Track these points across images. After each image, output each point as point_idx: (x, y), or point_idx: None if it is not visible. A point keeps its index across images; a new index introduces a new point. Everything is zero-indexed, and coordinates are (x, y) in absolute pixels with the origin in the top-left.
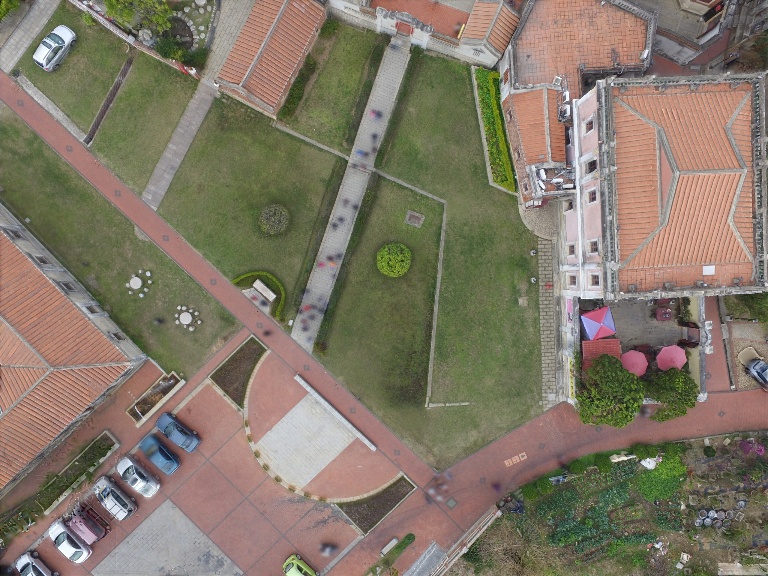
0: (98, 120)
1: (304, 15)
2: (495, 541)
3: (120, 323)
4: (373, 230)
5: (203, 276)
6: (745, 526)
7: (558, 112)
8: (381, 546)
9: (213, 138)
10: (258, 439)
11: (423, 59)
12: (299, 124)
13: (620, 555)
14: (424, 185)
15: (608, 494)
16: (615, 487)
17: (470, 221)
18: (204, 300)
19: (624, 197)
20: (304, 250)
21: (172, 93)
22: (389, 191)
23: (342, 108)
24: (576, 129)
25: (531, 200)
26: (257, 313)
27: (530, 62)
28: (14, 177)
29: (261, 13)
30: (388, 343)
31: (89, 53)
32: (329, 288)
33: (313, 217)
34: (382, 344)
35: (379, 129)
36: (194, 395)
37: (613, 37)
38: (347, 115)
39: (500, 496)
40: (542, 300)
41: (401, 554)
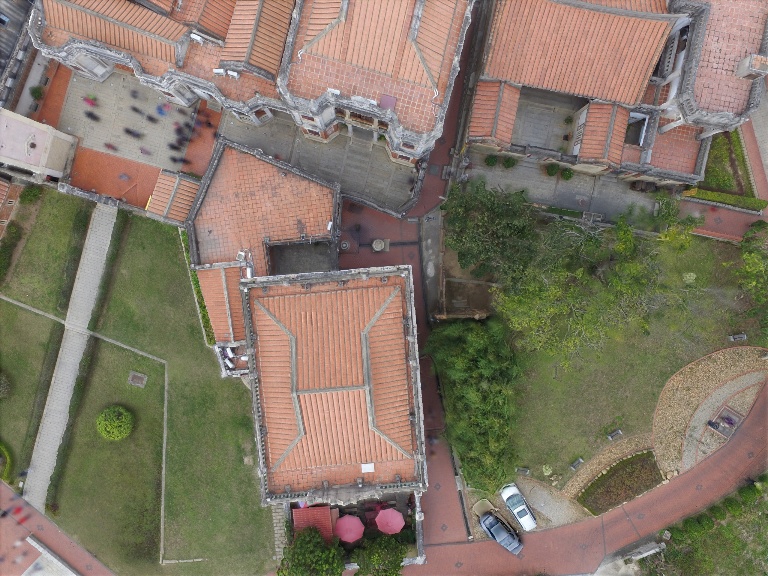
0: None
1: None
2: None
3: None
4: (96, 391)
5: None
6: None
7: None
8: None
9: None
10: None
11: (133, 219)
12: (11, 290)
13: None
14: (143, 346)
15: None
16: None
17: (191, 381)
18: None
19: (270, 401)
20: (29, 413)
21: None
22: (110, 352)
23: (53, 273)
24: None
25: None
26: None
27: (212, 237)
28: None
29: None
30: (120, 501)
31: None
32: (57, 450)
33: (35, 381)
34: (114, 503)
35: (93, 292)
36: None
37: (298, 208)
38: (59, 279)
39: None
40: None
41: None
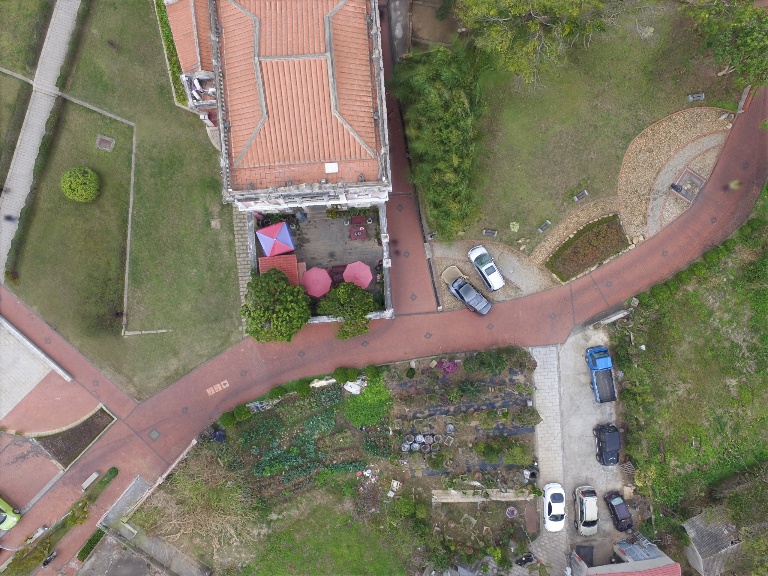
0: None
1: None
2: (195, 472)
3: None
4: (63, 155)
5: None
6: (457, 451)
7: None
8: (83, 481)
9: None
10: None
11: None
12: None
13: (329, 484)
14: (112, 108)
15: (312, 421)
16: (320, 413)
17: (159, 143)
18: None
19: (233, 93)
20: None
21: None
22: (78, 115)
23: (23, 31)
24: None
25: None
26: None
27: None
28: None
29: None
30: (82, 271)
31: None
32: (19, 216)
33: None
34: (76, 272)
35: (63, 52)
36: None
37: None
38: (29, 38)
39: (203, 426)
40: (236, 222)
41: (105, 489)
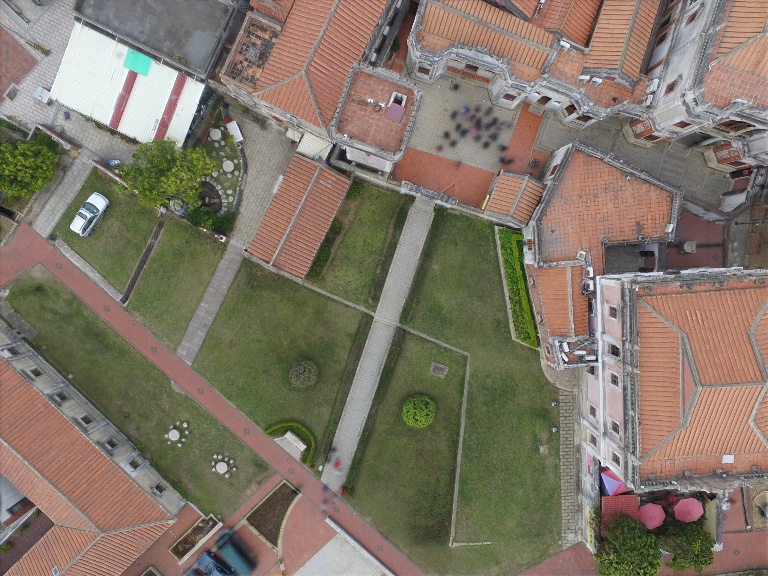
0: (133, 281)
1: (331, 190)
2: None
3: (160, 470)
4: (398, 381)
5: (237, 426)
6: None
7: (582, 285)
8: None
9: (243, 296)
10: (292, 574)
11: (447, 217)
12: (326, 283)
13: None
14: (448, 339)
15: None
16: None
17: (493, 373)
18: (238, 448)
19: (646, 394)
20: (332, 401)
21: (203, 254)
22: (414, 344)
23: (368, 267)
24: (599, 305)
25: (553, 364)
26: (289, 460)
27: (554, 237)
28: (56, 335)
29: (289, 190)
30: (413, 486)
31: (122, 217)
32: (357, 436)
33: (341, 370)
34: (408, 487)
35: (404, 286)
36: (231, 534)
37: (638, 210)
38: (372, 273)
39: None
40: (563, 448)
41: None
